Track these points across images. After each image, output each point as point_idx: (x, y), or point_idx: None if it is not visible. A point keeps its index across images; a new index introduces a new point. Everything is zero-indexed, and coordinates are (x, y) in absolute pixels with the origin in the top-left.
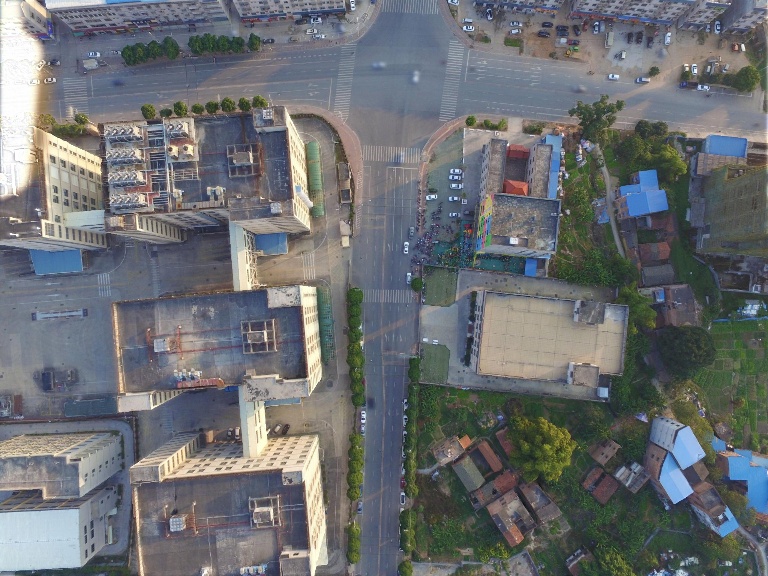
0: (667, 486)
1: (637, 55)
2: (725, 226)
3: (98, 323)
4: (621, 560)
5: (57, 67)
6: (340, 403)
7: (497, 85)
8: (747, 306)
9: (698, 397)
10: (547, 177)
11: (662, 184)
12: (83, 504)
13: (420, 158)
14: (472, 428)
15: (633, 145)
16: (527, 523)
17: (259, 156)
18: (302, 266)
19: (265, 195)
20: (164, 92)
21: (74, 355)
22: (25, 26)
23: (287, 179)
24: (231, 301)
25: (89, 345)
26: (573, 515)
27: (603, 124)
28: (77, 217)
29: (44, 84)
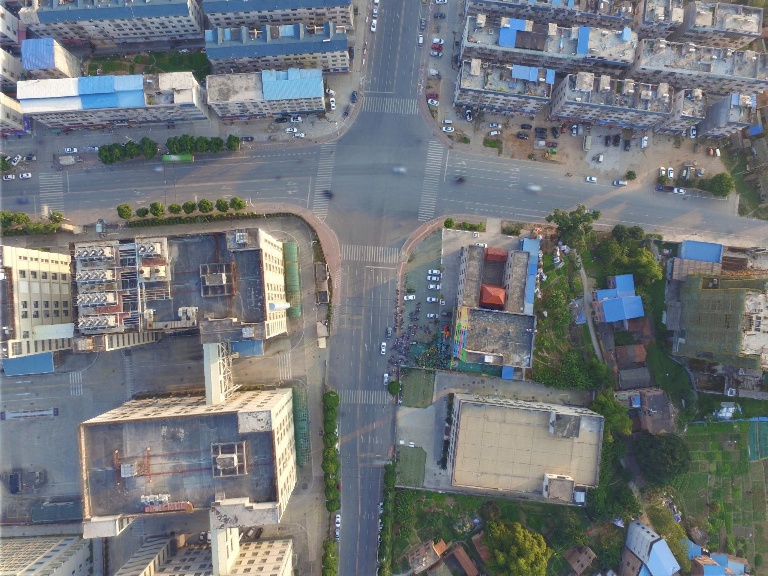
0: None
1: (614, 158)
2: (699, 337)
3: (69, 423)
4: None
5: (33, 162)
6: (315, 506)
7: (476, 186)
8: (722, 409)
9: (674, 501)
10: (524, 284)
11: (638, 288)
12: None
13: (398, 258)
14: (448, 533)
15: (609, 251)
16: None
17: (232, 276)
18: (278, 366)
19: (238, 314)
20: (141, 189)
21: (43, 455)
22: (0, 125)
23: (261, 298)
24: (201, 422)
25: (59, 445)
26: None
27: (579, 234)
28: (46, 331)
29: (19, 179)
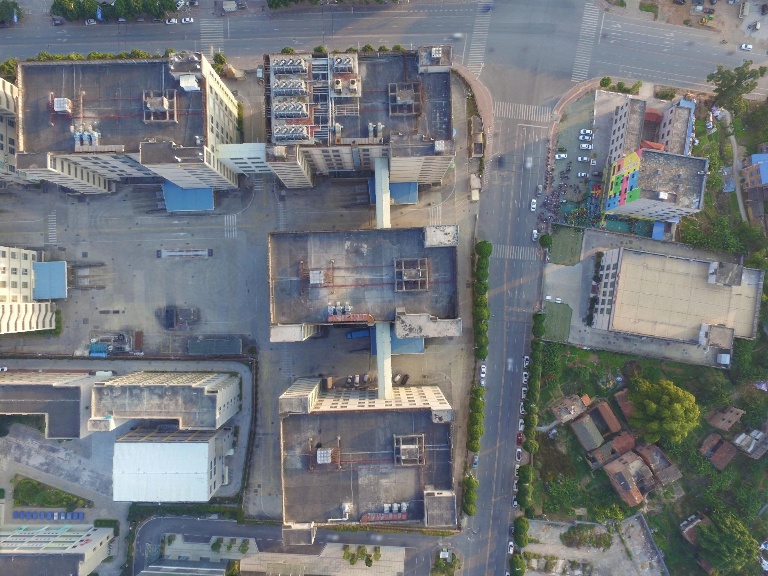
0: None
1: None
2: None
3: (223, 264)
4: (742, 525)
5: (195, 7)
6: (460, 356)
7: (630, 49)
8: None
9: None
10: (684, 140)
11: None
12: (210, 439)
13: (551, 117)
14: (592, 387)
15: None
16: (648, 484)
17: (421, 95)
18: (429, 218)
19: None
20: (300, 38)
21: (197, 294)
22: None
23: (445, 120)
24: (384, 238)
25: (212, 285)
26: (688, 480)
27: (745, 89)
28: (229, 149)
29: (181, 24)
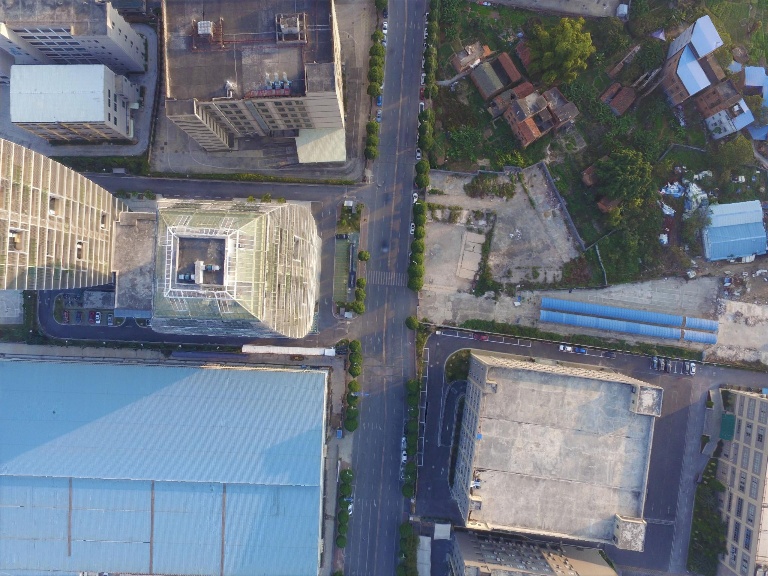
0: (684, 77)
1: None
2: None
3: None
4: None
5: None
6: (362, 15)
7: None
8: None
9: None
10: None
11: None
12: None
13: None
14: (492, 38)
15: None
16: (545, 118)
17: None
18: None
19: None
20: None
21: None
22: None
23: None
24: None
25: None
26: (589, 130)
27: None
28: None
29: None
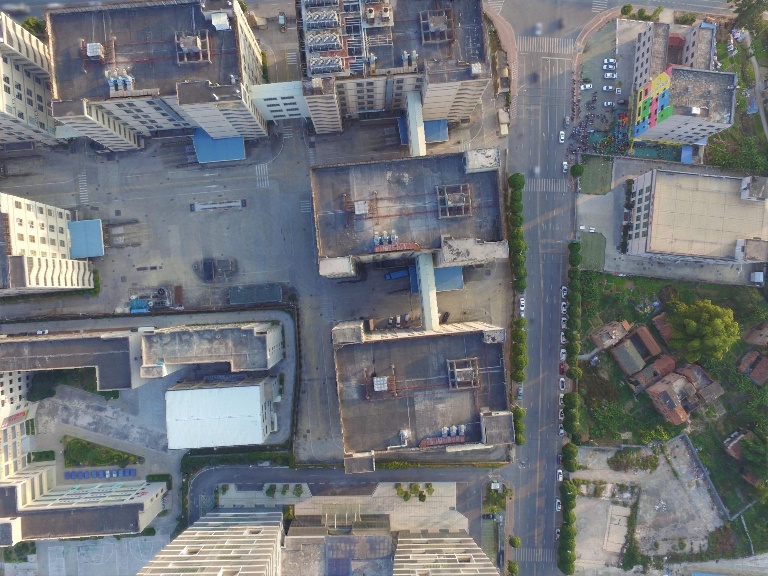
0: None
1: None
2: None
3: (257, 214)
4: None
5: None
6: (498, 291)
7: None
8: None
9: None
10: (709, 60)
11: None
12: (260, 383)
13: (574, 49)
14: (631, 313)
15: None
16: (692, 401)
17: (453, 21)
18: None
19: None
20: None
21: (233, 246)
22: None
23: (478, 46)
24: (425, 167)
25: (248, 236)
26: (729, 398)
27: (766, 6)
28: (263, 89)
29: None
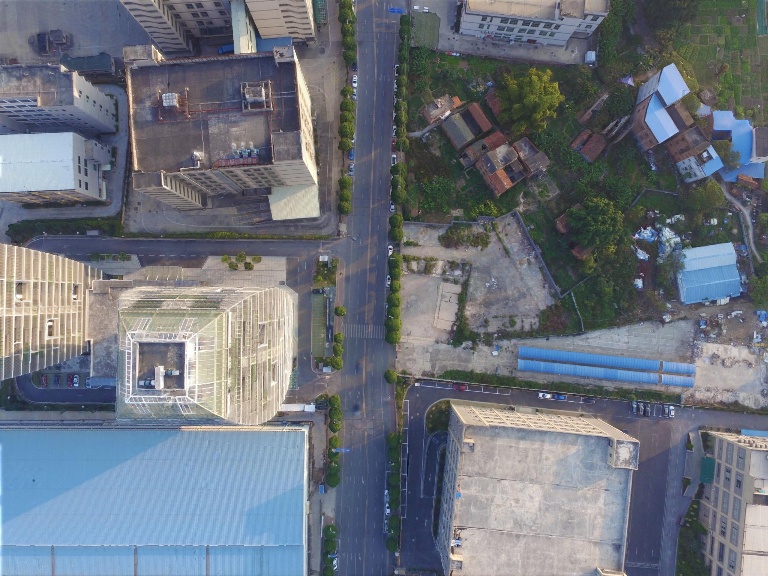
0: (653, 125)
1: None
2: None
3: None
4: (608, 201)
5: None
6: (332, 69)
7: None
8: None
9: (683, 66)
10: None
11: None
12: None
13: None
14: (462, 89)
15: None
16: (516, 169)
17: None
18: None
19: None
20: None
21: (69, 21)
22: None
23: None
24: None
25: (84, 11)
26: (561, 177)
27: None
28: None
29: None
